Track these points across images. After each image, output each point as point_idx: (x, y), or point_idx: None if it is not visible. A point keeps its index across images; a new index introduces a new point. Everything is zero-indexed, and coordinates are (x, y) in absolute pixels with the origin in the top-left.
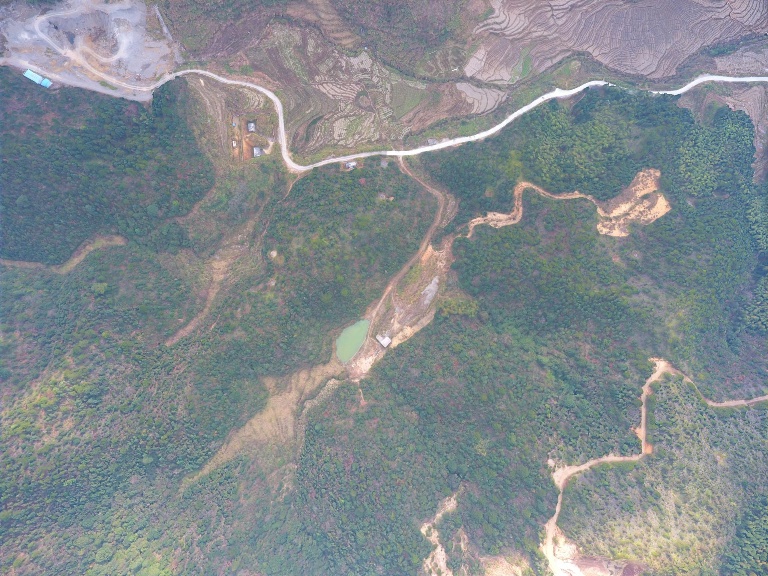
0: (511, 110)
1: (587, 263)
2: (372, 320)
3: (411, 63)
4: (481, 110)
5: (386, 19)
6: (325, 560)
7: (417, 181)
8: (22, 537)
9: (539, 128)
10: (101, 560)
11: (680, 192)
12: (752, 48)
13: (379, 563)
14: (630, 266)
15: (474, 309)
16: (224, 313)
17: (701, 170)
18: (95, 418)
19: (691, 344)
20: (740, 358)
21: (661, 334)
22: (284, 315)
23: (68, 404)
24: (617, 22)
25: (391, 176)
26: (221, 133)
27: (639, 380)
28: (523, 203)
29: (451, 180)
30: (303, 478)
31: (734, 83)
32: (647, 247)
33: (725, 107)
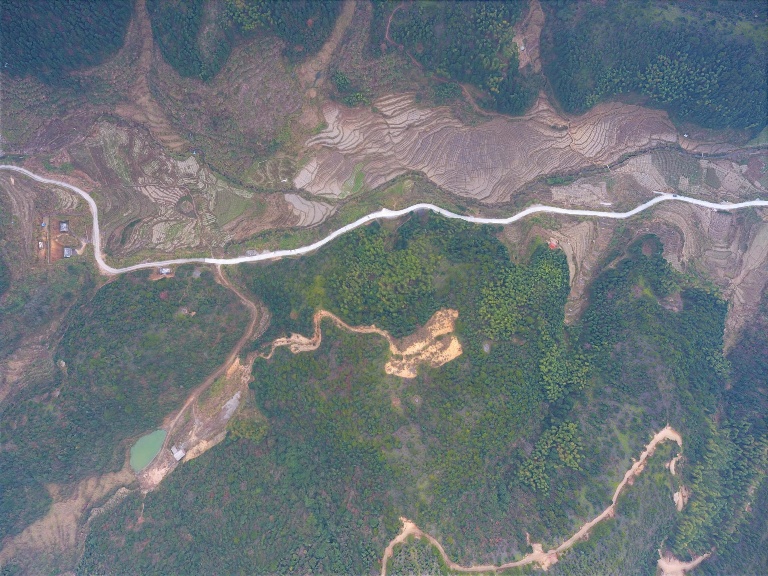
0: (334, 227)
1: (361, 408)
2: (169, 431)
3: (239, 171)
4: (307, 223)
5: (213, 128)
6: None
7: (232, 292)
8: None
9: (350, 254)
10: None
11: (475, 335)
12: (589, 180)
13: None
14: (406, 413)
15: (261, 434)
16: (2, 422)
17: (502, 313)
18: None
19: (441, 507)
20: (506, 516)
21: (412, 495)
22: (64, 428)
23: None
24: (455, 144)
25: (200, 288)
26: (26, 234)
27: (384, 540)
28: (321, 331)
29: (263, 295)
30: None
31: (566, 215)
32: (427, 394)
33: (542, 246)
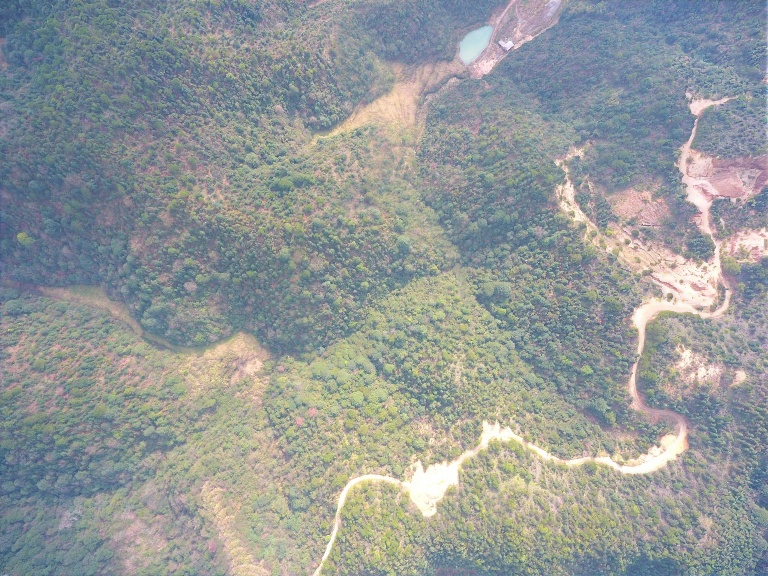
0: None
1: None
2: (496, 27)
3: None
4: None
5: None
6: (441, 228)
7: None
8: (185, 117)
9: None
10: (250, 161)
11: None
12: None
13: (510, 195)
14: None
15: None
16: None
17: None
18: (252, 36)
19: None
20: None
21: None
22: None
23: (229, 16)
24: None
25: None
26: None
27: None
28: None
29: None
30: (423, 158)
31: None
32: None
33: None
